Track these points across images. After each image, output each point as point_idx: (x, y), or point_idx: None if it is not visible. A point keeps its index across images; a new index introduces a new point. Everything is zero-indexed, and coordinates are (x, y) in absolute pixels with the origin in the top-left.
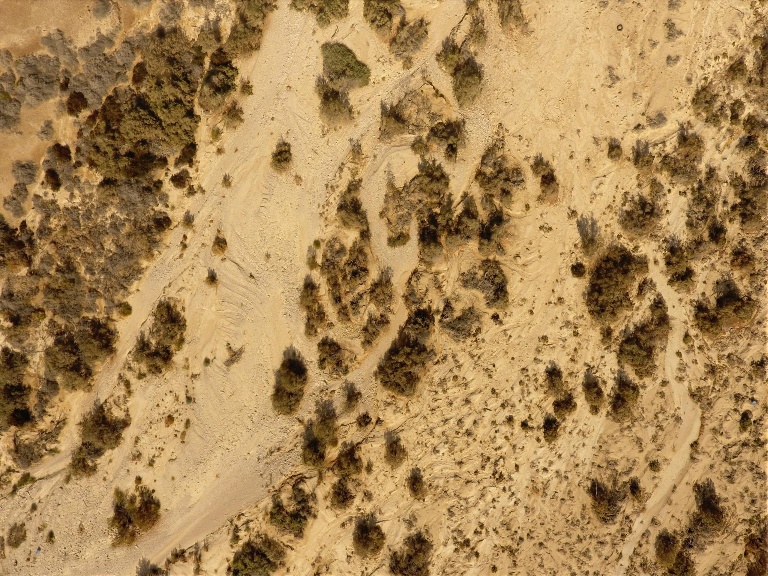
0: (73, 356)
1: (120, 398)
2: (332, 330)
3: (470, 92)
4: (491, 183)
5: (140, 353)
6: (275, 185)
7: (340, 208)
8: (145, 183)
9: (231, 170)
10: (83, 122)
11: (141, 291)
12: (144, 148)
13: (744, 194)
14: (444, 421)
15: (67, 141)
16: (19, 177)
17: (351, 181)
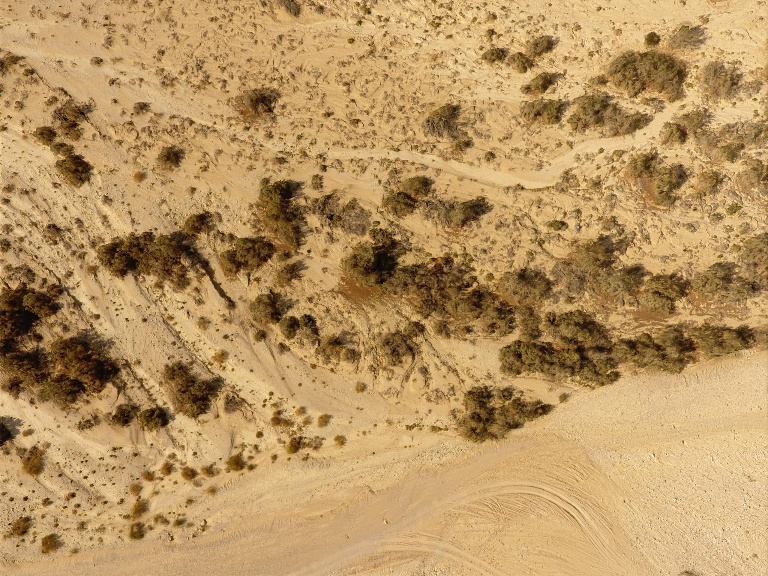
0: None
1: None
2: None
3: None
4: None
5: None
6: None
7: None
8: None
9: None
10: None
11: None
12: None
13: None
14: None
15: None
16: None
17: None
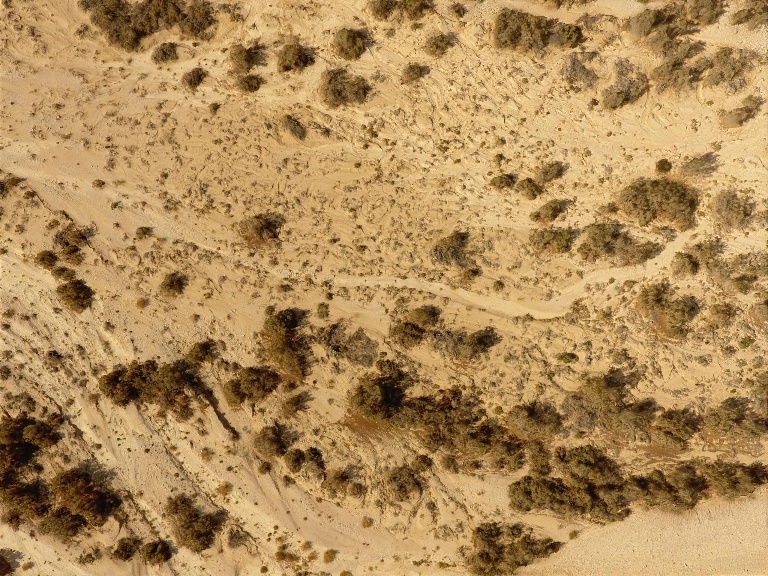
0: None
1: None
2: None
3: None
4: (727, 57)
5: None
6: None
7: None
8: None
9: None
10: None
11: None
12: None
13: None
14: (482, 82)
15: None
16: None
17: None
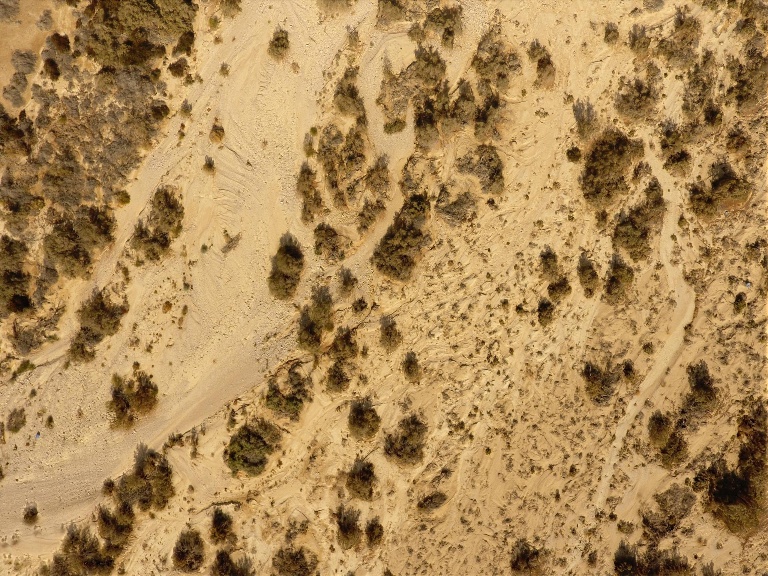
0: (72, 242)
1: (118, 285)
2: (328, 216)
3: None
4: (487, 67)
5: (138, 239)
6: (272, 73)
7: (337, 94)
8: (143, 72)
9: (229, 59)
10: (82, 12)
11: (139, 180)
12: (142, 35)
13: (740, 76)
14: (439, 305)
15: (66, 31)
16: (18, 66)
17: (348, 68)
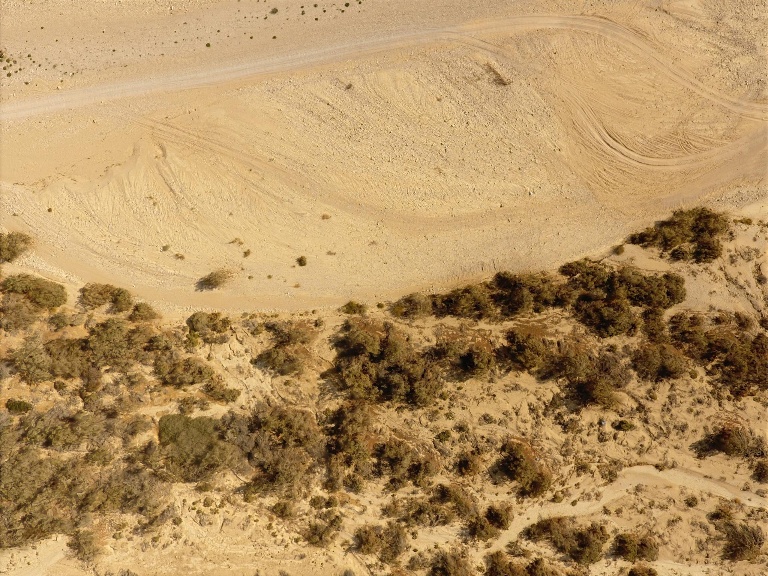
0: None
1: None
2: None
3: None
4: None
5: None
6: None
7: None
8: None
9: None
10: None
11: None
12: None
13: None
14: None
15: None
16: None
17: None
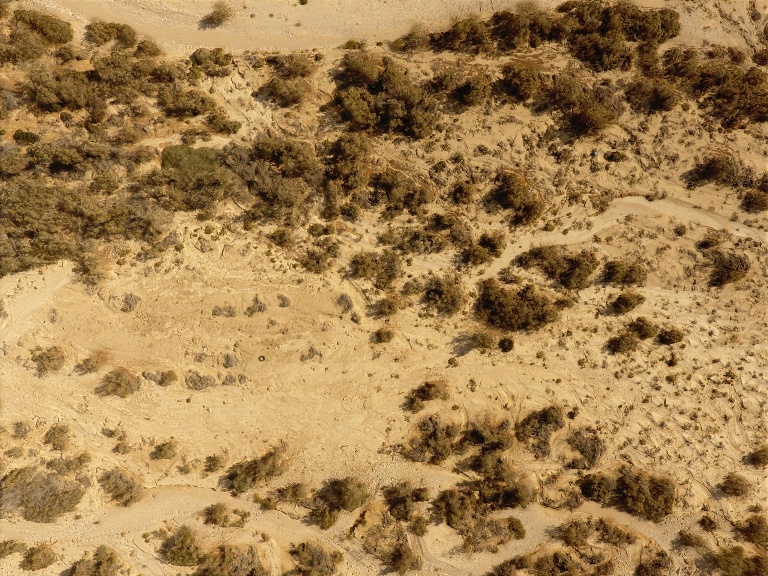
0: None
1: None
2: None
3: (359, 497)
4: (442, 453)
5: None
6: None
7: None
8: None
9: None
10: None
11: None
12: None
13: None
14: (688, 444)
15: None
16: None
17: None
